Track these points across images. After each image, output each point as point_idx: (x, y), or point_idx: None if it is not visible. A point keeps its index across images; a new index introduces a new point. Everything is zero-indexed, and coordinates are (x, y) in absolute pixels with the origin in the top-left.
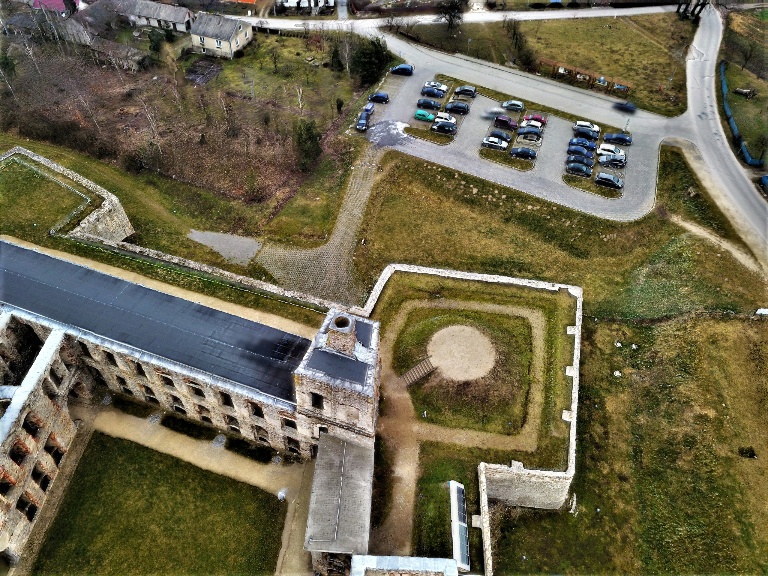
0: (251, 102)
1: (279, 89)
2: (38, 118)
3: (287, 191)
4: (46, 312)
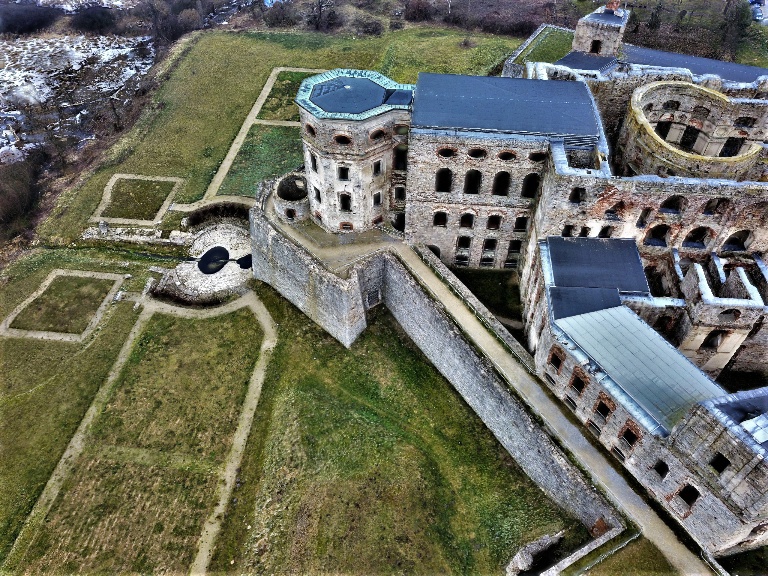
0: (648, 9)
1: (662, 1)
2: (499, 19)
3: (730, 56)
4: (725, 77)
